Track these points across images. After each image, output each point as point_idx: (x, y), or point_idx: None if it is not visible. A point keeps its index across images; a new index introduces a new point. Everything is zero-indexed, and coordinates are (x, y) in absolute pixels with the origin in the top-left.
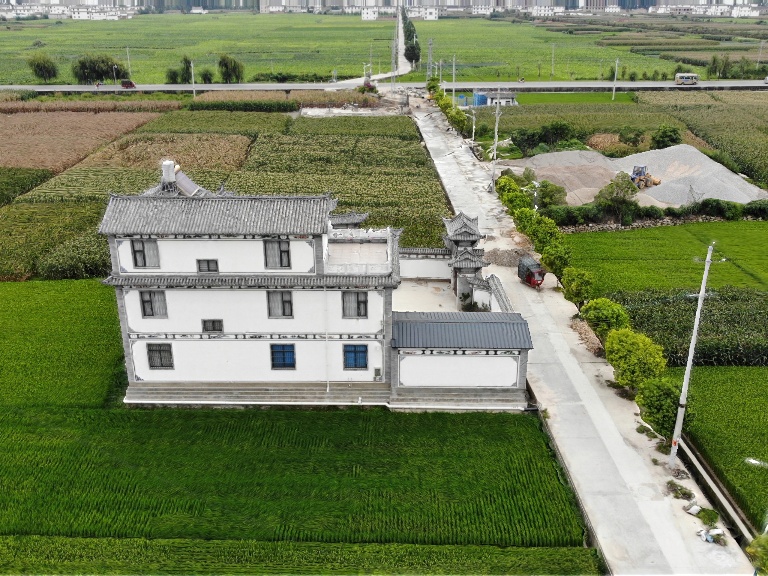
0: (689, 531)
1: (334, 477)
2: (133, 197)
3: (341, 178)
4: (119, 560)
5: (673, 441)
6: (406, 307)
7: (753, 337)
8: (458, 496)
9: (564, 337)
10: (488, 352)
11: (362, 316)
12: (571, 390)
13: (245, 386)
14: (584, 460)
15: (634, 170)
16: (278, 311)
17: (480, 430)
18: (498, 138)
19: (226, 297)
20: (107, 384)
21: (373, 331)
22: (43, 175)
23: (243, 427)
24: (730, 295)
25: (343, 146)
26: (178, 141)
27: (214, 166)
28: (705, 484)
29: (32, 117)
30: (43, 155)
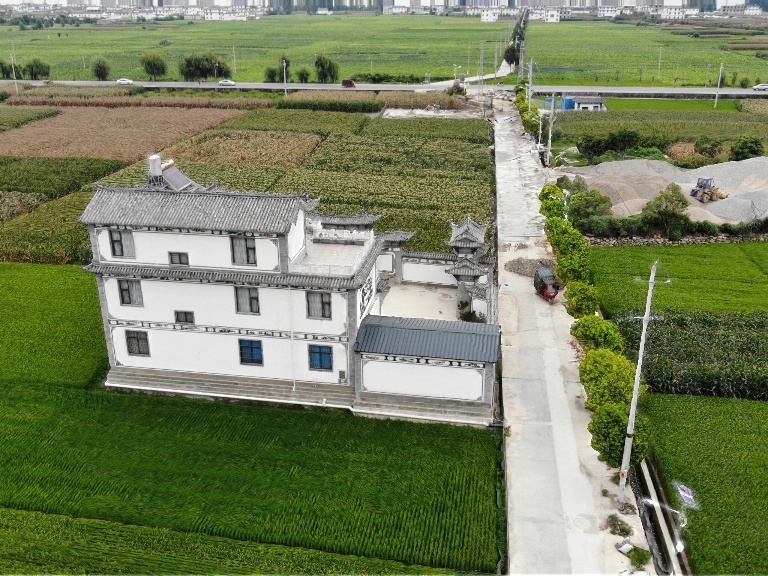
0: (612, 570)
1: (269, 475)
2: (117, 189)
3: (392, 179)
4: (39, 534)
5: (621, 472)
6: (405, 312)
7: (762, 368)
8: (383, 507)
9: (559, 353)
10: (452, 363)
11: (326, 317)
12: (544, 409)
13: (216, 378)
14: (528, 483)
15: (698, 182)
16: (246, 307)
17: (433, 442)
18: (571, 144)
19: (196, 290)
20: (96, 366)
21: (337, 333)
22: (117, 166)
23: (203, 418)
24: (756, 321)
25: (408, 147)
26: (251, 138)
27: (275, 163)
28: (656, 522)
29: (130, 111)
30: (124, 147)
